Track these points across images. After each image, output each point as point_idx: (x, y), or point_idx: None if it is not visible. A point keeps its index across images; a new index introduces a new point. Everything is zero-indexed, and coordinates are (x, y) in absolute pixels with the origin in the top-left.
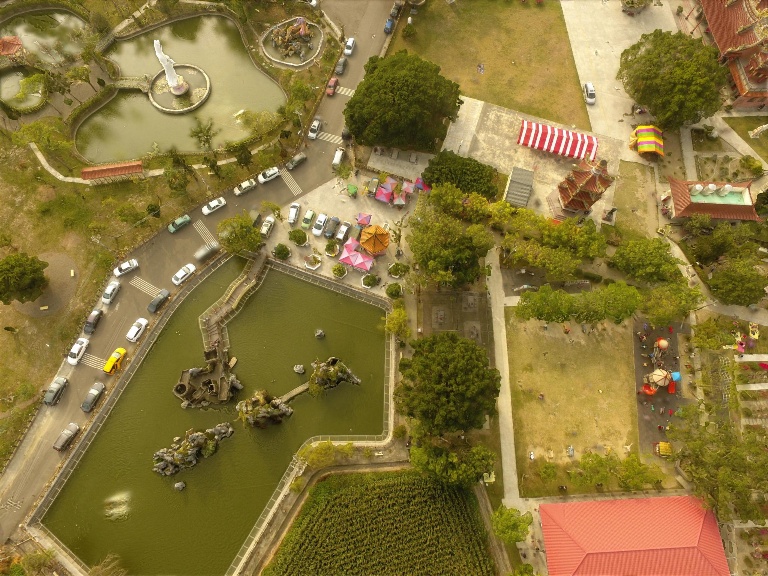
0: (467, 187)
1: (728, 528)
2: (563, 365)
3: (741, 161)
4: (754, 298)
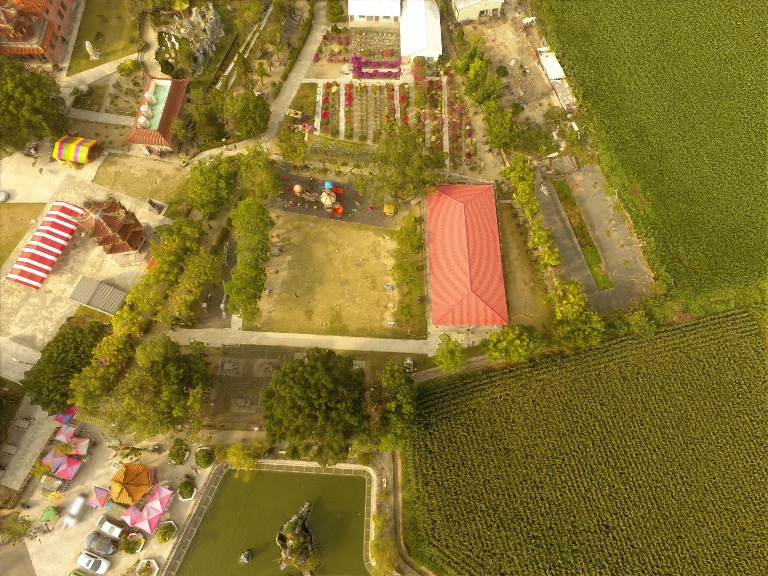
0: (83, 358)
1: (450, 176)
2: (309, 281)
3: (122, 75)
4: (264, 106)
